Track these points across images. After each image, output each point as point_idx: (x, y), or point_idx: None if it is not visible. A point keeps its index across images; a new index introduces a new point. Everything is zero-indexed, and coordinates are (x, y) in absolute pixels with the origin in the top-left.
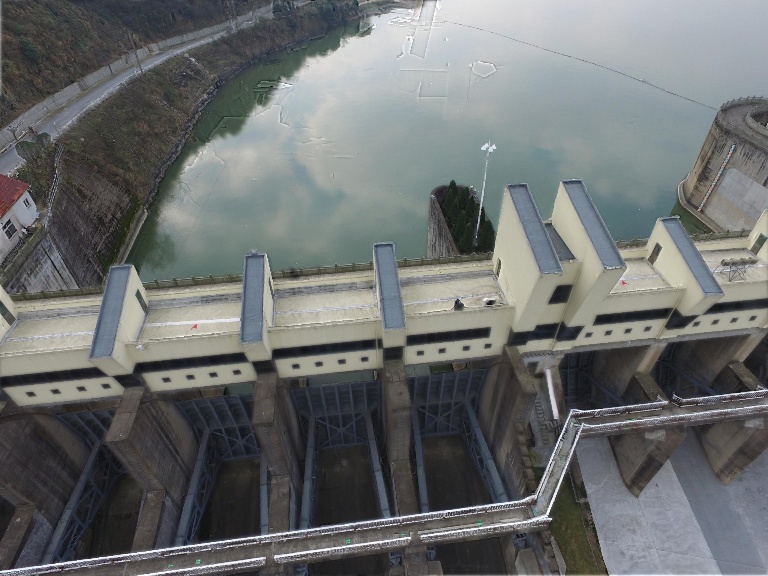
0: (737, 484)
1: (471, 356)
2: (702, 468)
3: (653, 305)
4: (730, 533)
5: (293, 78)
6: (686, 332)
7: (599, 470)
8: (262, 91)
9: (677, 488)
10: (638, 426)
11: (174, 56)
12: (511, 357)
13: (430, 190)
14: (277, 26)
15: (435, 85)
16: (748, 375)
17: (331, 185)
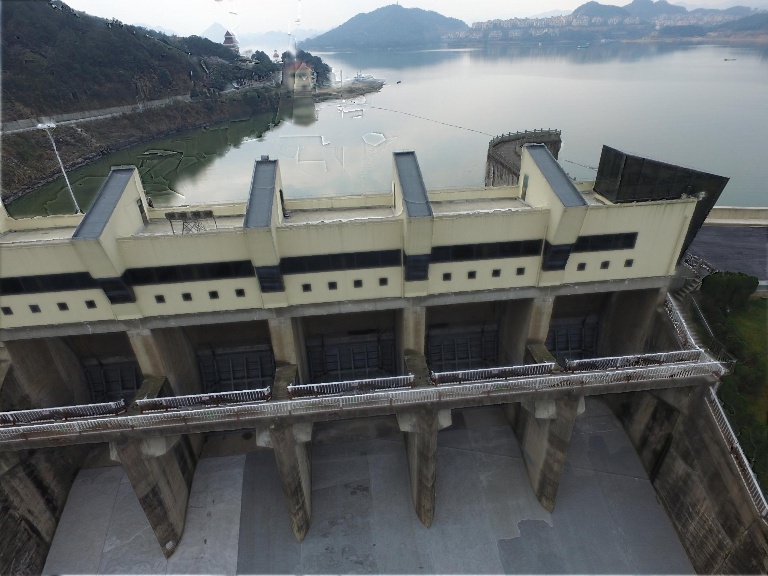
0: (317, 541)
1: None
2: (280, 518)
3: (64, 266)
4: None
5: (216, 156)
6: (158, 312)
7: (138, 519)
8: (145, 157)
9: (231, 546)
10: (56, 435)
11: None
12: None
13: None
14: (192, 108)
15: (312, 150)
16: (287, 379)
17: None
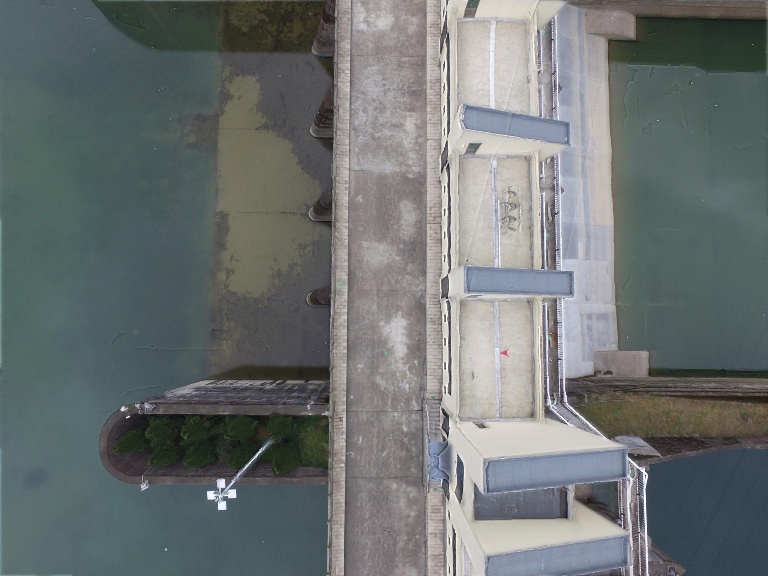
0: None
1: None
2: None
3: None
4: None
5: None
6: None
7: None
8: None
9: None
10: None
11: None
12: None
13: None
14: None
15: None
16: None
17: None
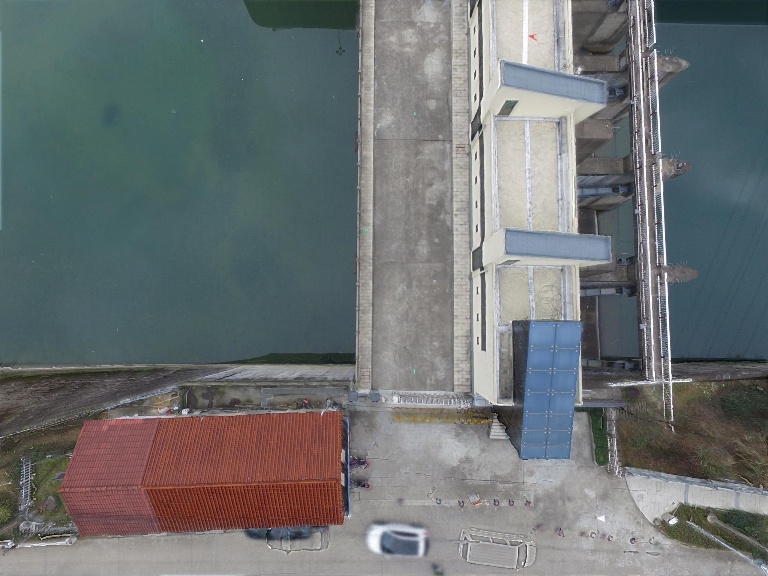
0: None
1: None
2: None
3: None
4: None
5: None
6: None
7: None
8: None
9: None
10: None
11: None
12: None
13: None
14: None
15: None
16: None
17: None
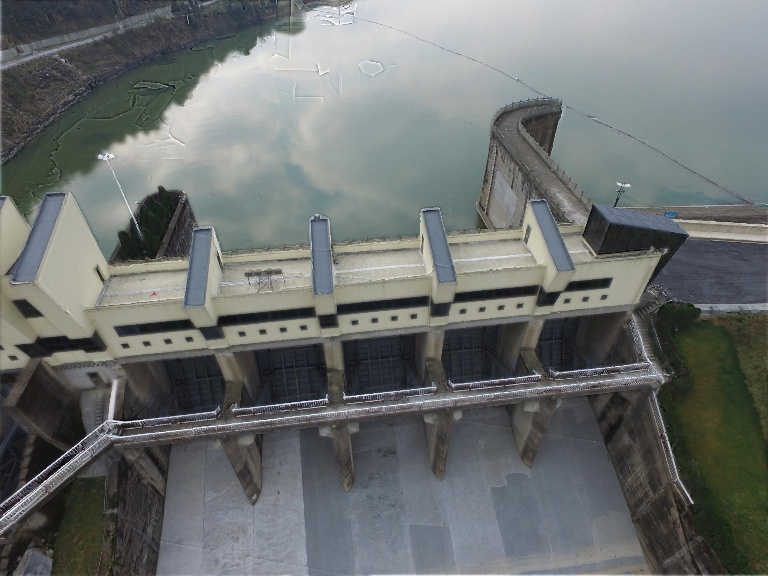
0: (360, 491)
1: (5, 368)
2: (331, 475)
3: (170, 316)
4: (334, 540)
5: (203, 77)
6: (240, 342)
7: (226, 478)
8: (136, 92)
9: (298, 495)
10: (178, 437)
11: (39, 57)
12: (24, 369)
13: (240, 193)
14: (175, 25)
15: (309, 85)
16: (338, 383)
17: (145, 188)
